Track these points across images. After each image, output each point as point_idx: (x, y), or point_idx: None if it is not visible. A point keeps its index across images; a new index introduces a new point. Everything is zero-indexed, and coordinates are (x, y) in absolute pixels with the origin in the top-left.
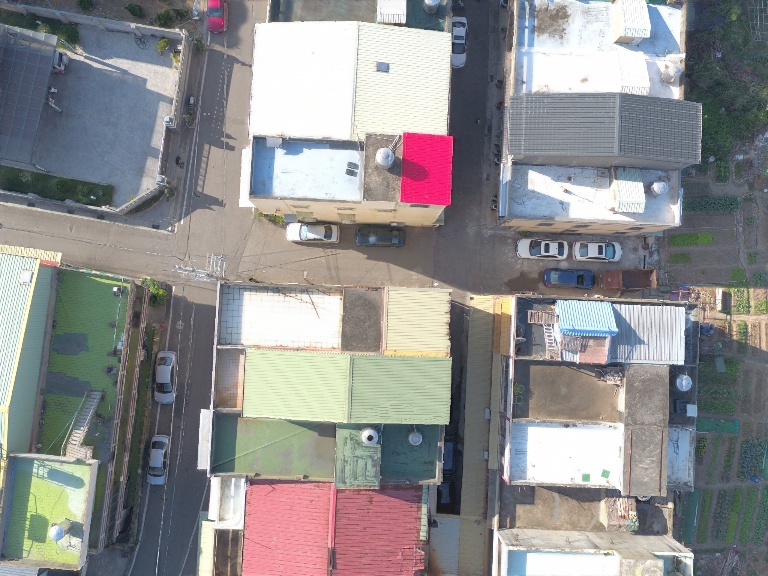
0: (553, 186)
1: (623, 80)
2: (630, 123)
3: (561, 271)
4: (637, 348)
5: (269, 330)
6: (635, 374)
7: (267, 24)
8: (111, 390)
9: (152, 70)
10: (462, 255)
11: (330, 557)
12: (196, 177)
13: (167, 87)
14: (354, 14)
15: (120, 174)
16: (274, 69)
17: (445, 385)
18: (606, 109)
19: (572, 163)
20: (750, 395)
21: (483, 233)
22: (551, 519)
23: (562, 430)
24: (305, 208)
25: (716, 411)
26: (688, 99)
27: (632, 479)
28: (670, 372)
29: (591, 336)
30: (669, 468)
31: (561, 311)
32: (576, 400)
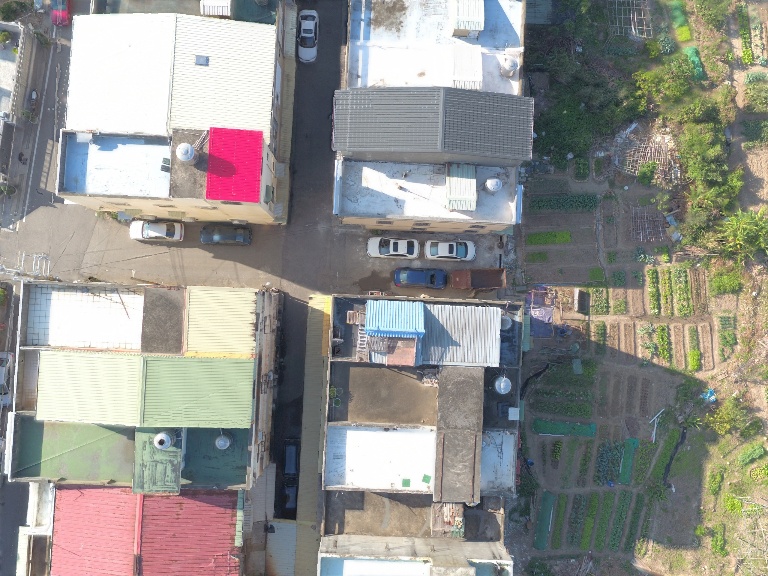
0: (388, 183)
1: (455, 74)
2: (455, 118)
3: (411, 270)
4: (450, 350)
5: (77, 331)
6: (448, 376)
7: (85, 16)
8: None
9: None
10: (311, 254)
11: (136, 564)
12: (39, 174)
13: (10, 82)
14: (183, 6)
15: None
16: (91, 62)
17: (246, 388)
18: (430, 104)
19: (405, 159)
20: (607, 397)
21: (334, 231)
22: (381, 525)
23: (382, 434)
24: (128, 205)
25: (572, 414)
26: (547, 94)
27: (444, 485)
28: (494, 374)
29: (399, 337)
30: (493, 473)
31: (369, 311)
32: (397, 403)
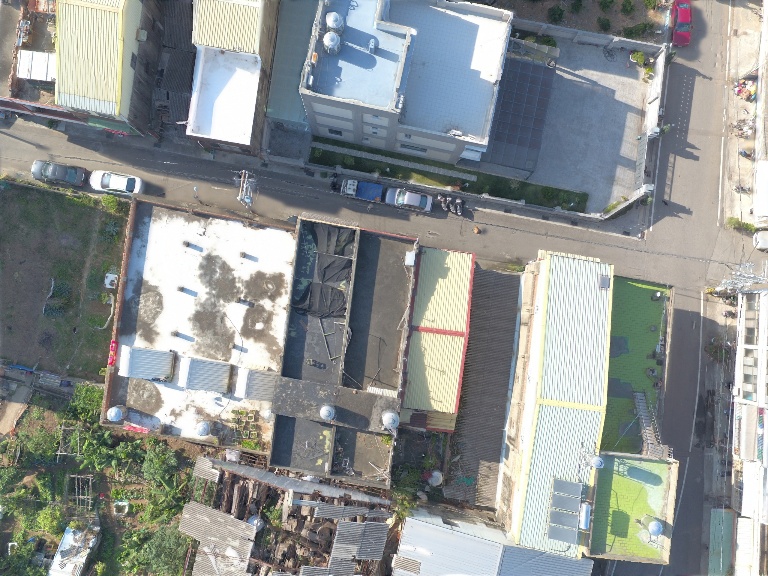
0: None
1: None
2: None
3: None
4: None
5: None
6: None
7: None
8: (651, 391)
9: (620, 82)
10: None
11: None
12: (663, 186)
13: (634, 98)
14: None
15: (592, 182)
16: None
17: None
18: None
19: None
20: None
21: None
22: None
23: None
24: None
25: None
26: None
27: None
28: None
29: None
30: None
31: None
32: None
